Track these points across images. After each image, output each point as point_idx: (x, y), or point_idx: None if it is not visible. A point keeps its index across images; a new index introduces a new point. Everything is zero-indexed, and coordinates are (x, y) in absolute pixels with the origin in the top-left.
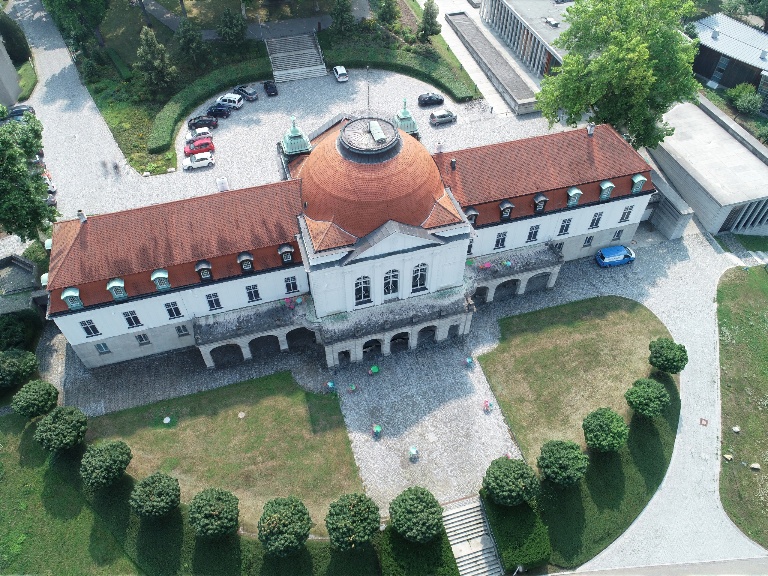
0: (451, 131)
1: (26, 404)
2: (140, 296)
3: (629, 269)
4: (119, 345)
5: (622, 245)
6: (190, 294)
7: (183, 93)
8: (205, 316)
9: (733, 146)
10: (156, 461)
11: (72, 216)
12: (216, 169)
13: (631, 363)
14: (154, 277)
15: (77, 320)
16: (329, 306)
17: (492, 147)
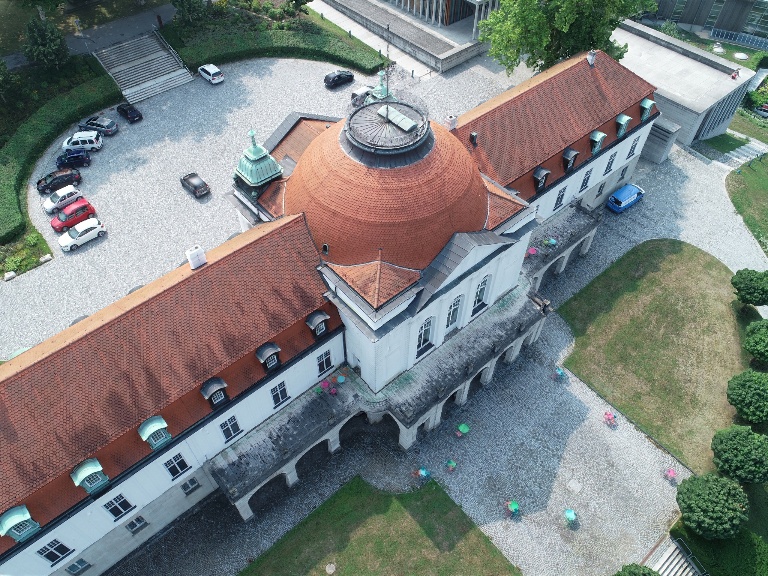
0: None
1: None
2: (128, 470)
3: (643, 207)
4: (102, 550)
5: (626, 183)
6: (199, 434)
7: (8, 148)
8: (220, 453)
9: (663, 53)
10: None
11: None
12: (112, 238)
13: (711, 308)
14: (146, 434)
15: (32, 551)
16: (389, 372)
17: (505, 106)
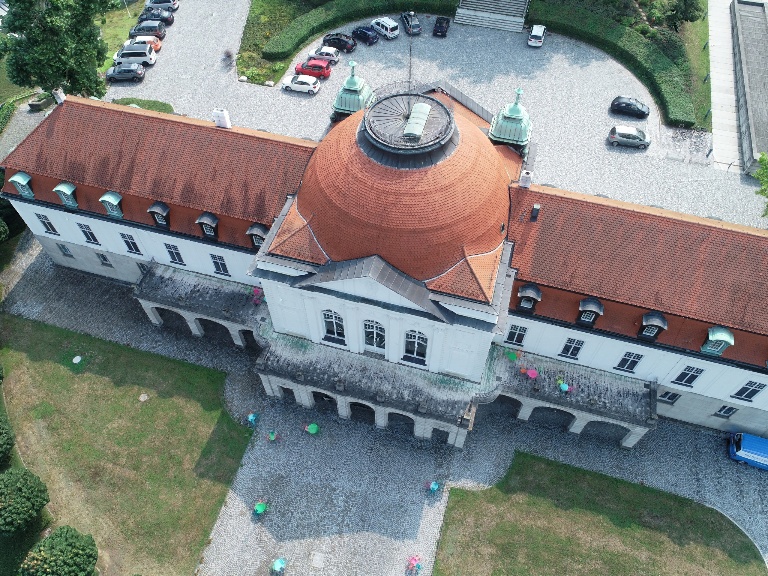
0: (629, 160)
1: None
2: (90, 213)
3: None
4: (81, 254)
5: None
6: (146, 234)
7: (342, 1)
8: (167, 265)
9: None
10: (35, 399)
11: (147, 96)
12: (314, 100)
13: None
14: (102, 198)
15: (32, 210)
16: (288, 324)
17: (612, 210)
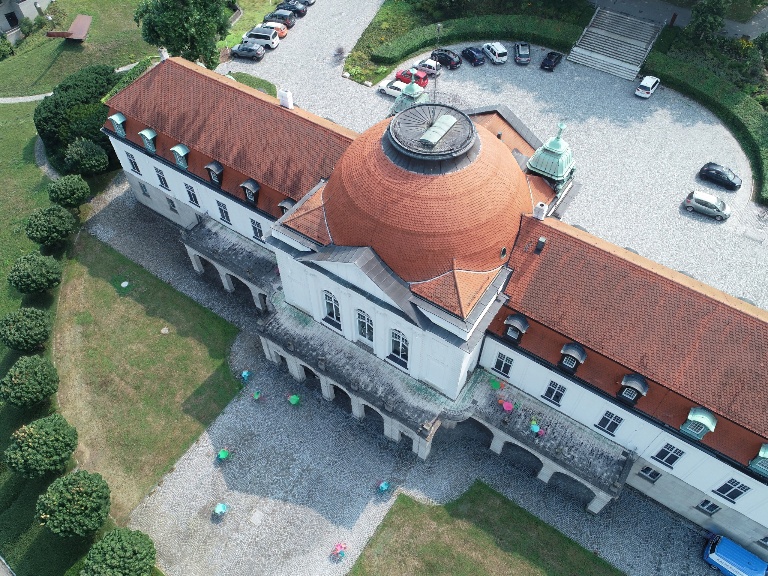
0: (699, 228)
1: (53, 188)
2: (164, 159)
3: None
4: (156, 196)
5: None
6: (203, 188)
7: (462, 21)
8: (217, 221)
9: None
10: (81, 307)
11: (259, 75)
12: None
13: None
14: (173, 148)
15: (124, 148)
16: (296, 298)
17: (618, 261)
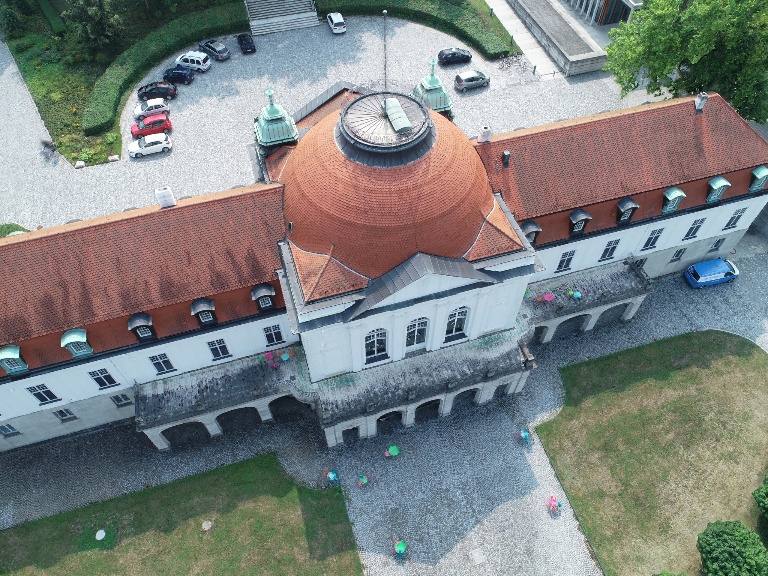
0: (483, 99)
1: None
2: (48, 367)
3: (730, 290)
4: (31, 424)
5: (720, 257)
6: (125, 358)
7: (131, 51)
8: (152, 381)
9: None
10: None
11: None
12: (174, 156)
13: (748, 433)
14: (65, 342)
15: None
16: (328, 367)
17: (561, 131)
